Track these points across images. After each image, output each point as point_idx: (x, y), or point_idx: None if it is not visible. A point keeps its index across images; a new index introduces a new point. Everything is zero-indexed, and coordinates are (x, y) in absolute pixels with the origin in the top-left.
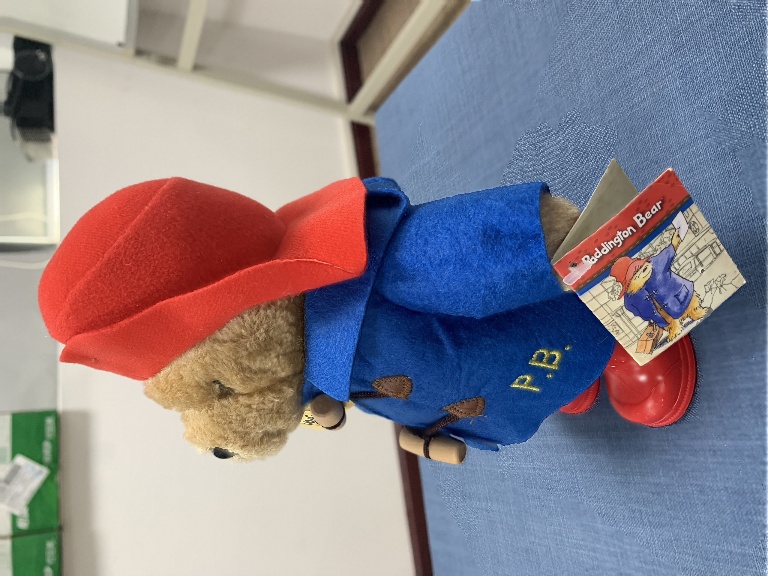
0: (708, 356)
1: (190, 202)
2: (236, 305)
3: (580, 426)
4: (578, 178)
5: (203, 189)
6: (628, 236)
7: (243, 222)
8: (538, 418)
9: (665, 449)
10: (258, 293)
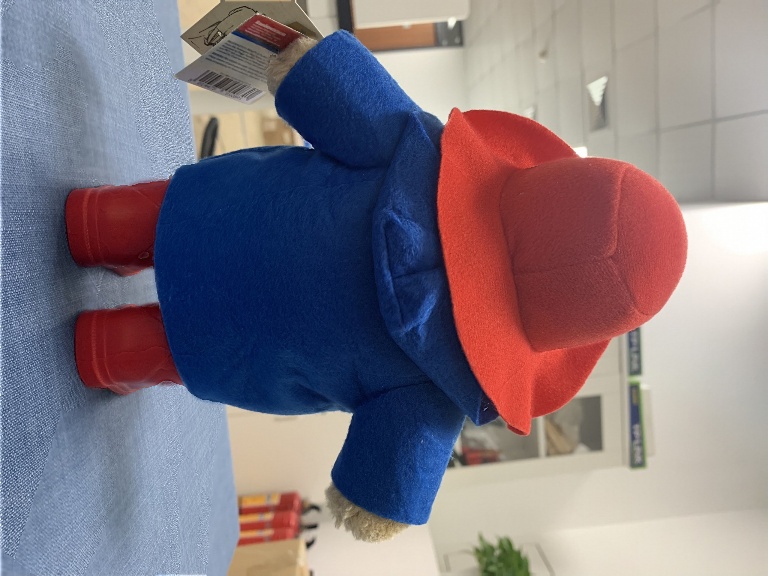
0: (107, 173)
1: (593, 165)
2: None
3: None
4: (1, 311)
5: (587, 186)
6: (286, 18)
7: (544, 171)
8: None
9: None
10: None
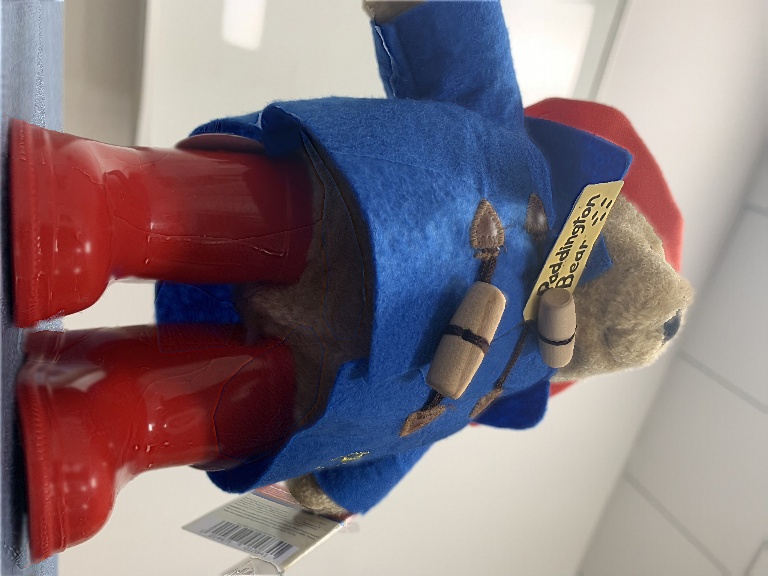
0: None
1: None
2: None
3: None
4: None
5: None
6: None
7: None
8: (307, 433)
9: None
10: None
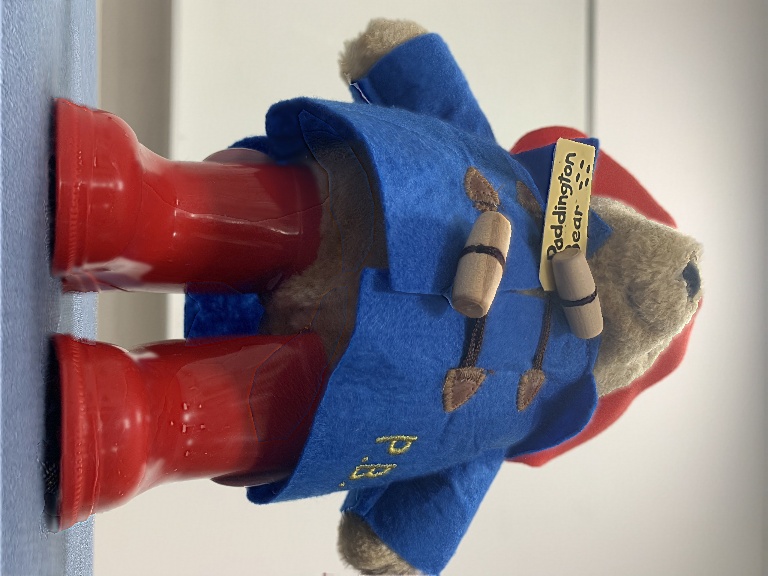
0: None
1: None
2: (607, 421)
3: None
4: None
5: None
6: None
7: None
8: (343, 376)
9: None
10: (591, 431)
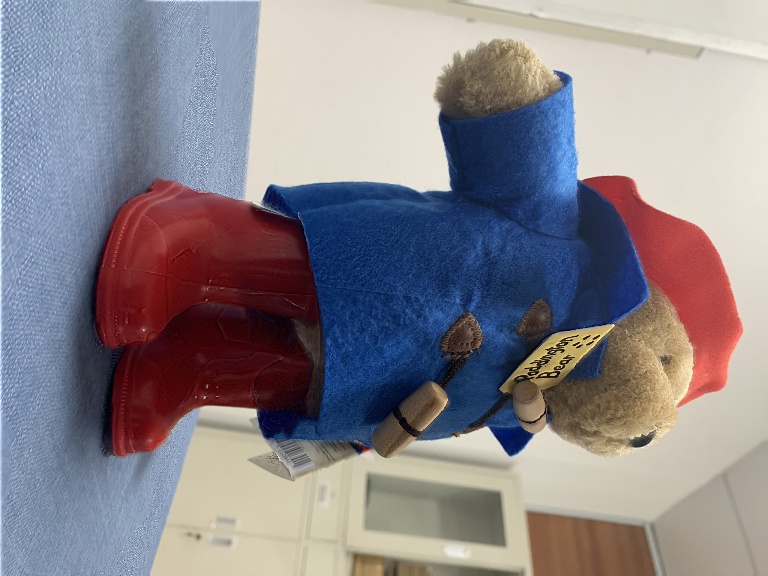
0: None
1: None
2: None
3: (85, 346)
4: None
5: None
6: None
7: None
8: None
9: (90, 470)
10: None
